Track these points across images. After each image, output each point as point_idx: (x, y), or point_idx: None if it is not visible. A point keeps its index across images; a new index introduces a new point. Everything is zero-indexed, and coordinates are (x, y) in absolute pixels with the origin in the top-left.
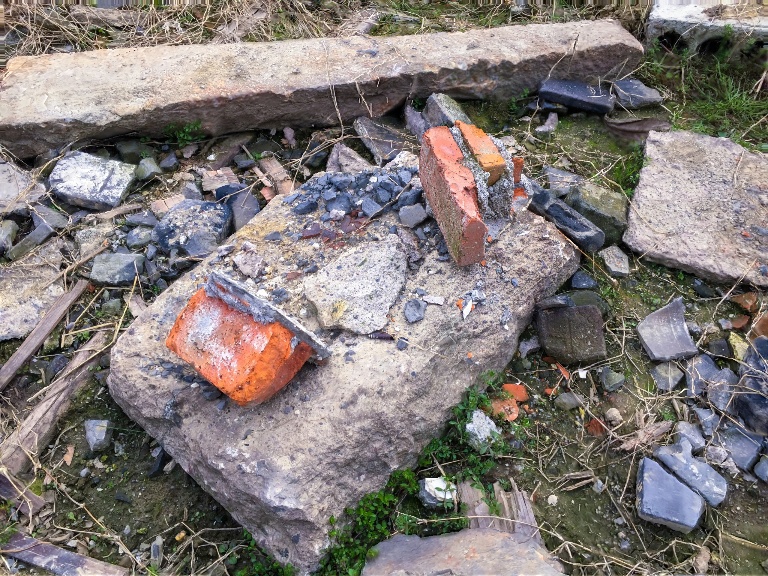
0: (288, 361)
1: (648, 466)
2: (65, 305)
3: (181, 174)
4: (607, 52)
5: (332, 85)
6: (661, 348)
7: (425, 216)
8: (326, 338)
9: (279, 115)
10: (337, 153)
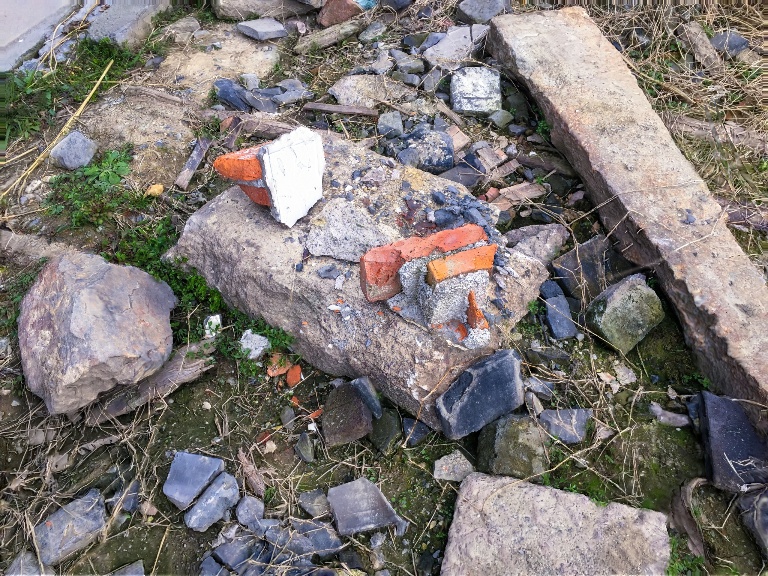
0: (258, 190)
1: (214, 461)
2: (359, 111)
3: (505, 139)
4: None
5: (617, 195)
6: (340, 496)
7: None
8: None
9: (584, 177)
10: None
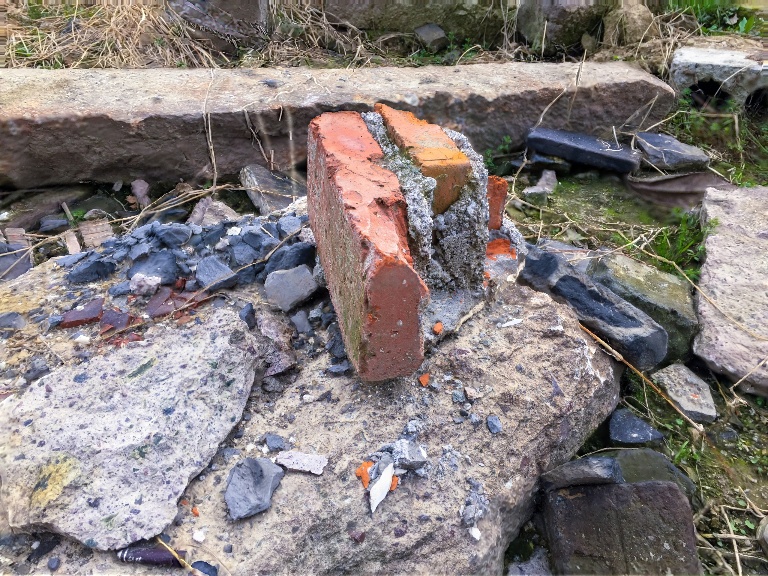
0: None
1: None
2: None
3: None
4: (623, 93)
5: (207, 113)
6: None
7: (312, 287)
8: (19, 556)
9: (123, 157)
10: (203, 211)
